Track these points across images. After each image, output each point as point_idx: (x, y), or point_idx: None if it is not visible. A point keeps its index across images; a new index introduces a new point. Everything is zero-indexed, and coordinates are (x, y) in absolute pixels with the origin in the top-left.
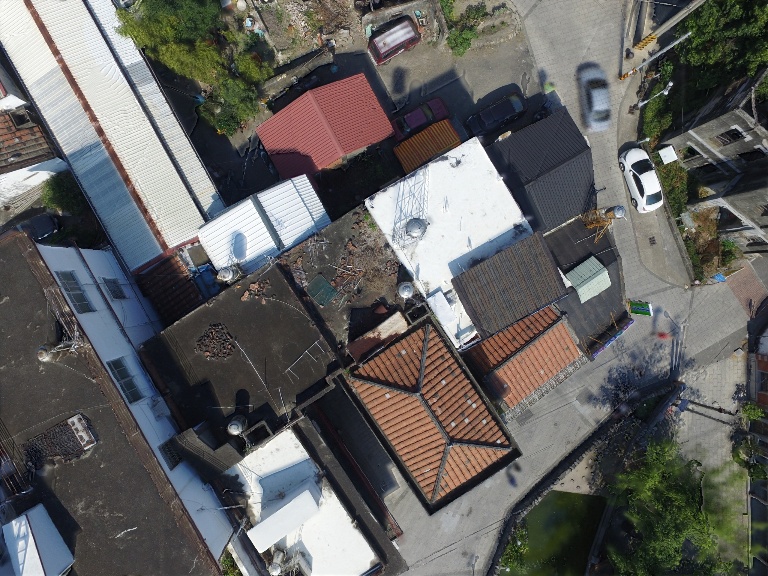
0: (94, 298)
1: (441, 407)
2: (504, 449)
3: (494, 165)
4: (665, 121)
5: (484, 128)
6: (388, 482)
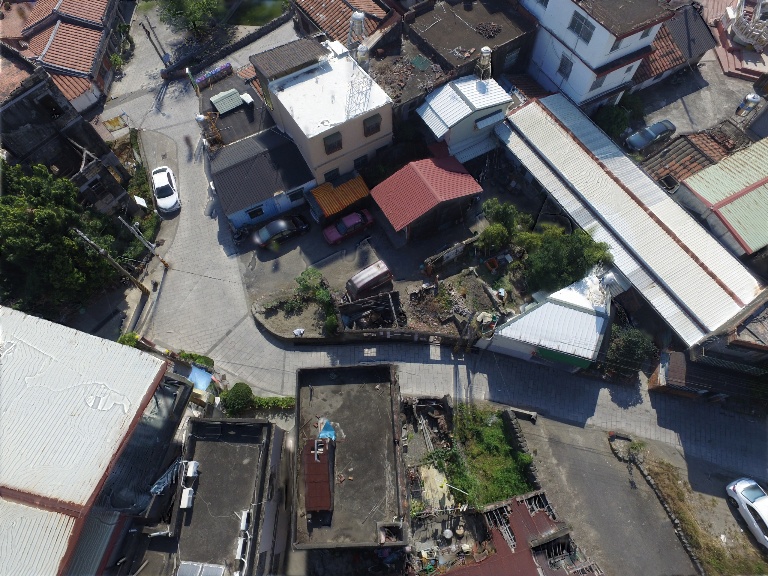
0: (572, 38)
1: (340, 8)
2: None
3: (290, 172)
4: (139, 219)
5: (293, 218)
6: None
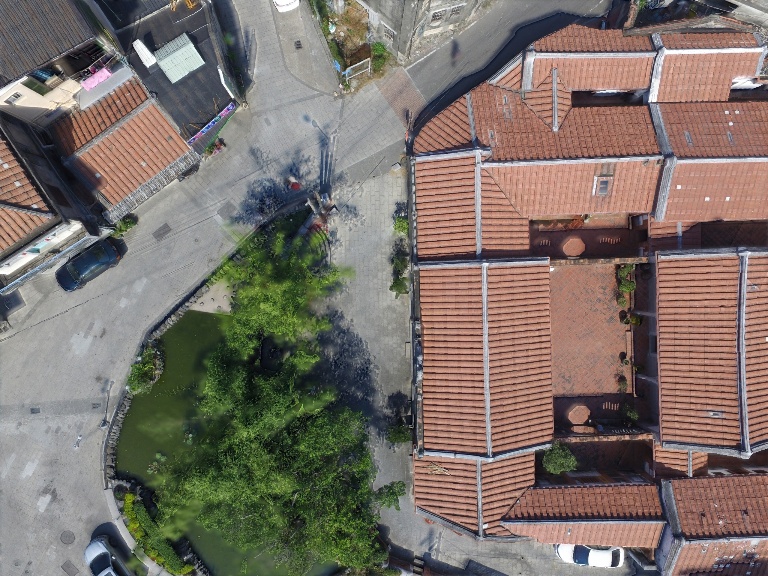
0: None
1: None
2: (38, 213)
3: None
4: None
5: None
6: (13, 299)
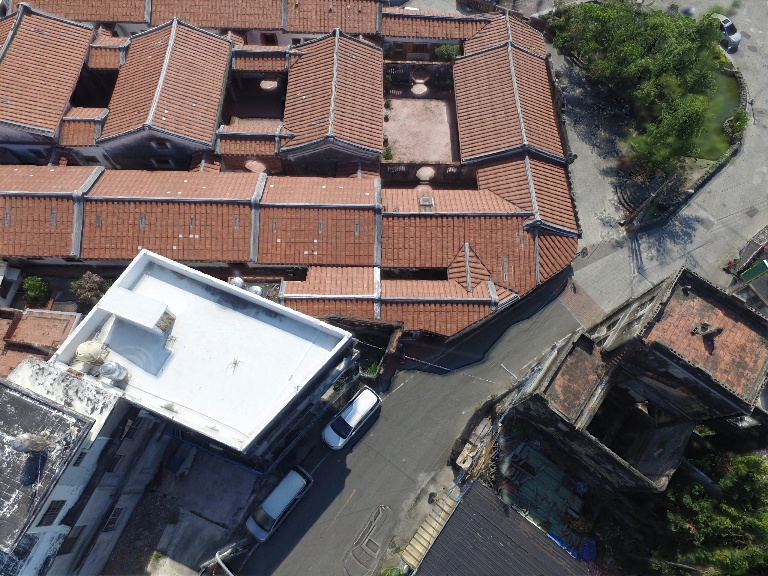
0: None
1: None
2: None
3: None
4: None
5: None
6: None
